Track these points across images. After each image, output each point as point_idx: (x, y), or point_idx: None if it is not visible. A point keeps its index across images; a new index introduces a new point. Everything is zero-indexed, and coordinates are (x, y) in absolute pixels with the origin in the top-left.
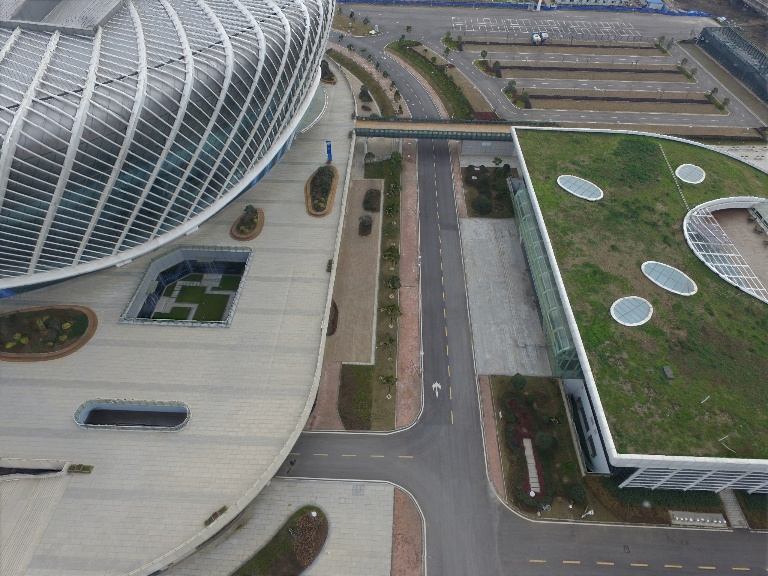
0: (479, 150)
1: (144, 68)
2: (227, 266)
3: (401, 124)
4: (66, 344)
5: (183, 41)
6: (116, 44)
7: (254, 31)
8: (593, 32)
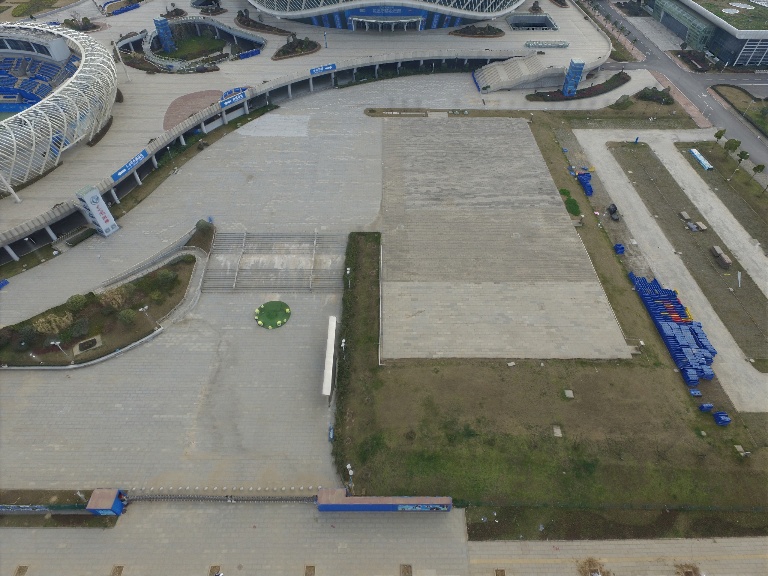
0: None
1: None
2: None
3: None
4: (499, 33)
5: None
6: None
7: None
8: None
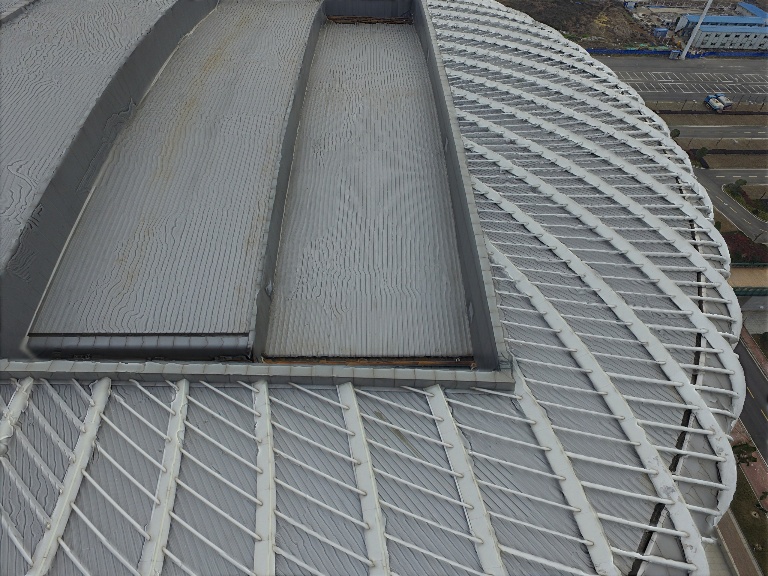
0: (766, 305)
1: (679, 494)
2: None
3: None
4: None
5: (665, 362)
6: (570, 408)
7: (714, 284)
8: (767, 90)
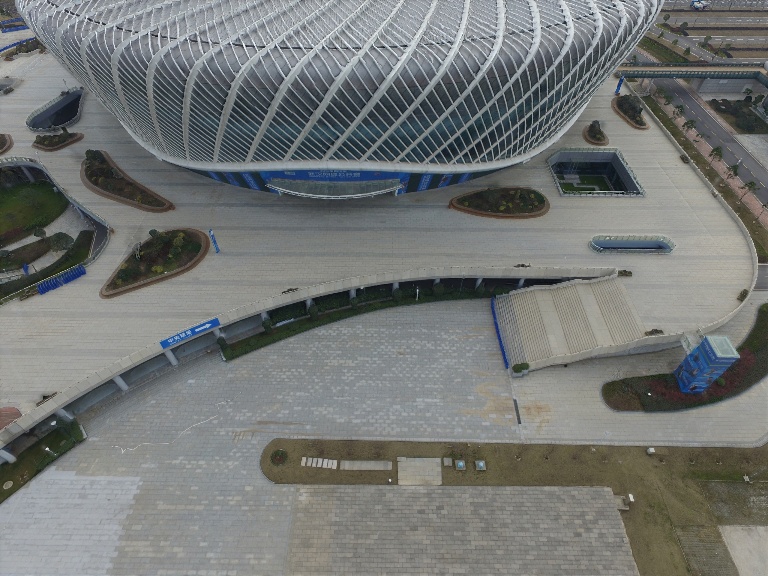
0: (715, 88)
1: None
2: (586, 167)
3: (649, 68)
4: (540, 207)
5: None
6: None
7: None
8: (738, 0)
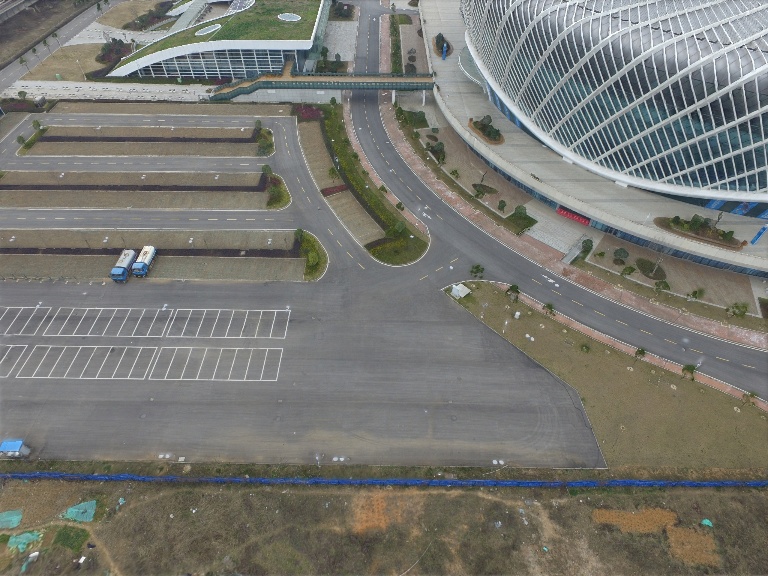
0: None
1: None
2: None
3: None
4: None
5: None
6: None
7: None
8: None
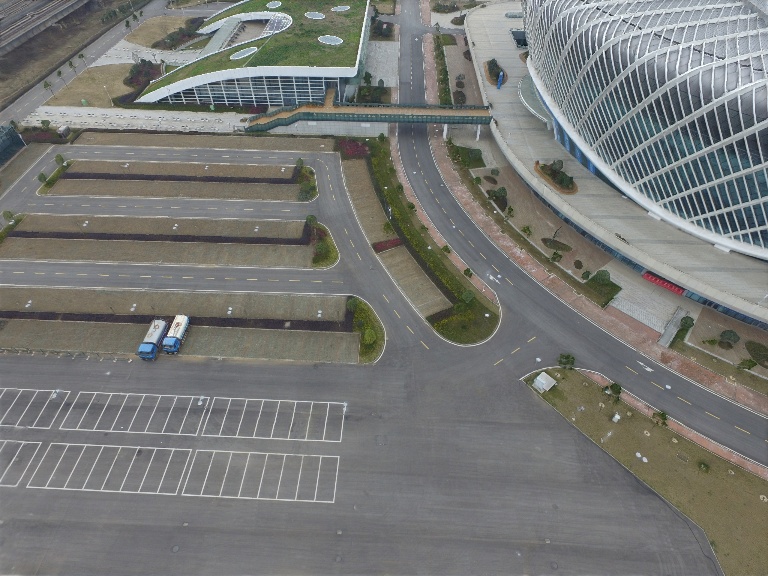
0: None
1: None
2: None
3: None
4: None
5: None
6: None
7: None
8: None
